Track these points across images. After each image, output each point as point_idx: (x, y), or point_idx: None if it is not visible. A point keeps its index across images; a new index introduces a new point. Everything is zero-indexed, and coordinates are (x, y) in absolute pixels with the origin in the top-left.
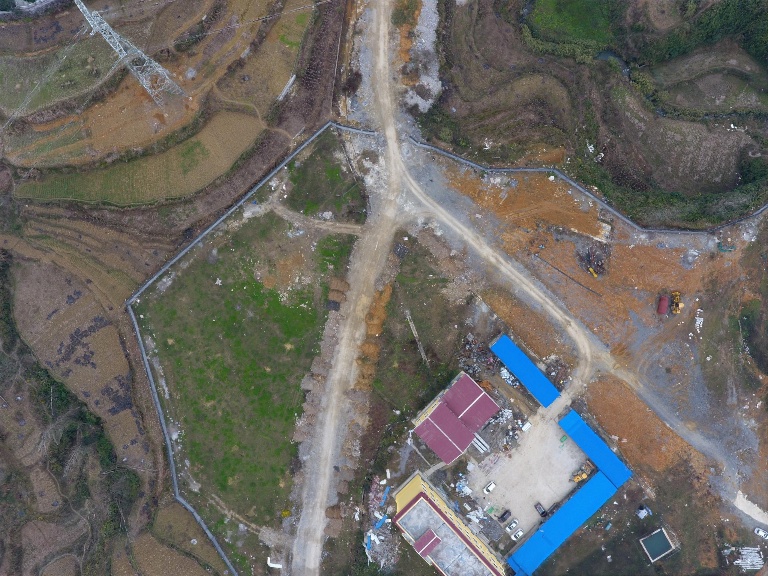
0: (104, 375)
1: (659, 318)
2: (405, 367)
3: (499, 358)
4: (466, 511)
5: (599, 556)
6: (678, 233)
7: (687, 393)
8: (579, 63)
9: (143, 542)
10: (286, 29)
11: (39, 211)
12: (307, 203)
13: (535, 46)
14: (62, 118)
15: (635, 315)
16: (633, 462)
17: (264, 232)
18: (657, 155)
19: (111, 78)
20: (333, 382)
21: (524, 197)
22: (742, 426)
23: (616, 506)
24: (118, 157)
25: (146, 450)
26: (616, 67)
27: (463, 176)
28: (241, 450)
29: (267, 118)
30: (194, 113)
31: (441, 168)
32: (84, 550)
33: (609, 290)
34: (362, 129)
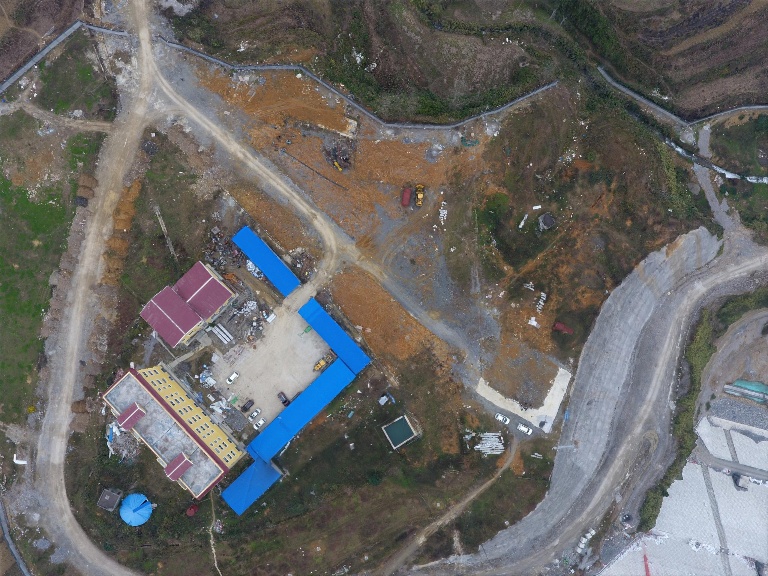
0: None
1: (404, 211)
2: (153, 262)
3: None
4: (210, 402)
5: (341, 444)
6: (423, 129)
7: (431, 283)
8: None
9: None
10: None
11: None
12: (57, 102)
13: None
14: None
15: (380, 208)
16: (377, 351)
17: (13, 130)
18: (433, 67)
19: None
20: (80, 277)
21: (272, 94)
22: (485, 315)
23: (360, 395)
24: None
25: None
26: None
27: (213, 75)
28: None
29: (13, 16)
30: None
31: (192, 67)
32: None
33: (355, 184)
34: (115, 30)
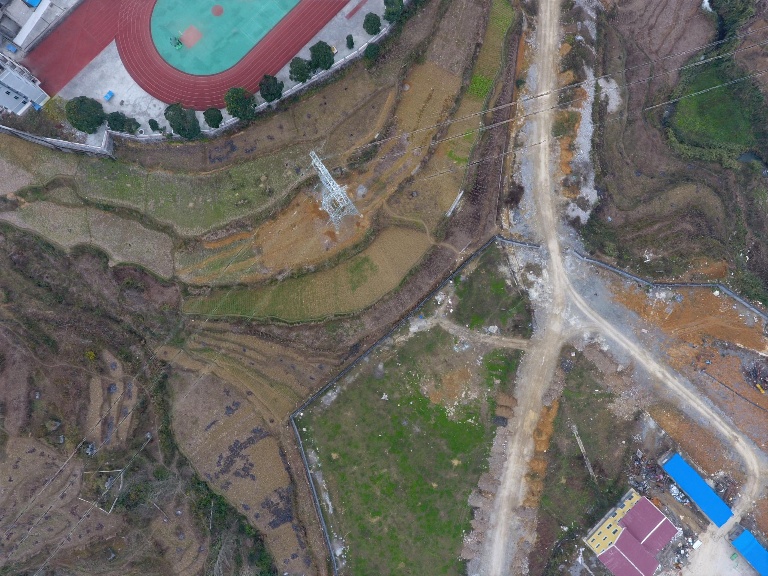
0: (264, 487)
1: None
2: (573, 483)
3: (668, 475)
4: None
5: None
6: None
7: None
8: (725, 168)
9: None
10: (453, 145)
11: (205, 326)
12: (472, 317)
13: (684, 152)
14: (233, 235)
15: None
16: None
17: (430, 346)
18: None
19: None
20: (502, 499)
21: (689, 312)
22: None
23: None
24: (289, 274)
25: (307, 564)
26: (758, 169)
27: (628, 290)
28: (408, 567)
29: (436, 234)
30: (365, 230)
31: (605, 282)
32: None
33: None
34: (525, 242)
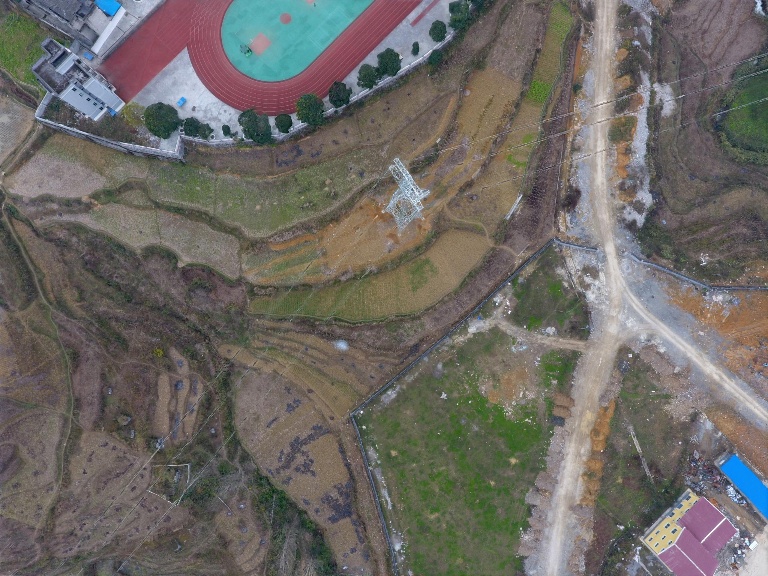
0: (324, 483)
1: None
2: (629, 483)
3: (725, 476)
4: None
5: None
6: None
7: None
8: None
9: None
10: None
11: (269, 325)
12: (530, 318)
13: (738, 156)
14: (298, 237)
15: None
16: None
17: (488, 347)
18: None
19: (349, 200)
20: (559, 497)
21: (747, 315)
22: None
23: None
24: (352, 275)
25: (366, 558)
26: None
27: (685, 293)
28: (465, 563)
29: (495, 237)
30: (426, 233)
31: (662, 285)
32: None
33: None
34: (582, 245)
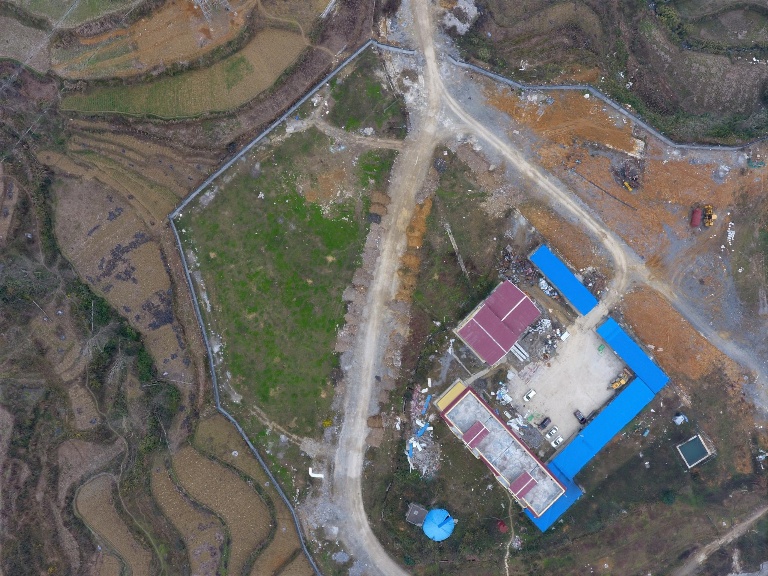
0: (145, 290)
1: (692, 231)
2: (445, 279)
3: (537, 269)
4: (506, 419)
5: (637, 462)
6: (709, 150)
7: (720, 304)
8: None
9: (183, 455)
10: None
11: (84, 125)
12: (348, 119)
13: None
14: (109, 32)
15: (669, 228)
16: (669, 371)
17: (306, 147)
18: (683, 86)
19: None
20: (375, 293)
21: (560, 114)
22: None
23: (653, 413)
24: (164, 70)
25: (187, 364)
26: (643, 1)
27: (501, 94)
28: (283, 361)
29: (310, 35)
30: (239, 28)
31: (479, 86)
32: (121, 469)
33: (643, 204)
34: (402, 49)
